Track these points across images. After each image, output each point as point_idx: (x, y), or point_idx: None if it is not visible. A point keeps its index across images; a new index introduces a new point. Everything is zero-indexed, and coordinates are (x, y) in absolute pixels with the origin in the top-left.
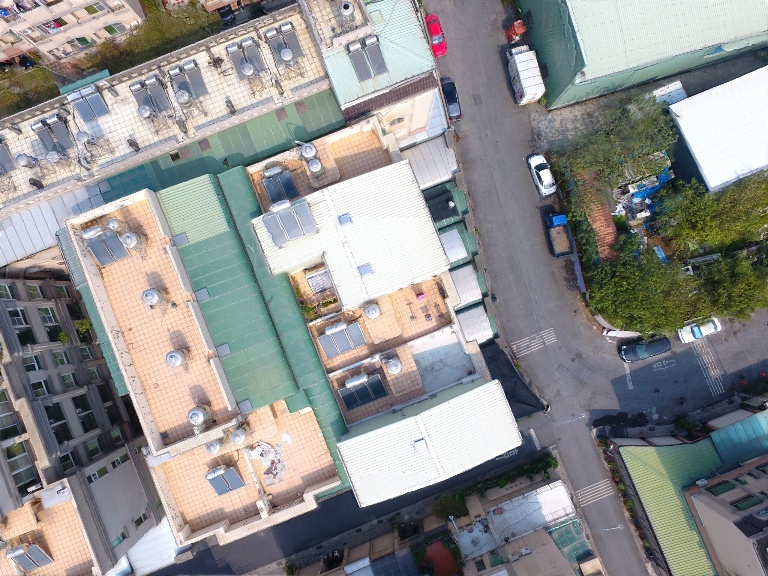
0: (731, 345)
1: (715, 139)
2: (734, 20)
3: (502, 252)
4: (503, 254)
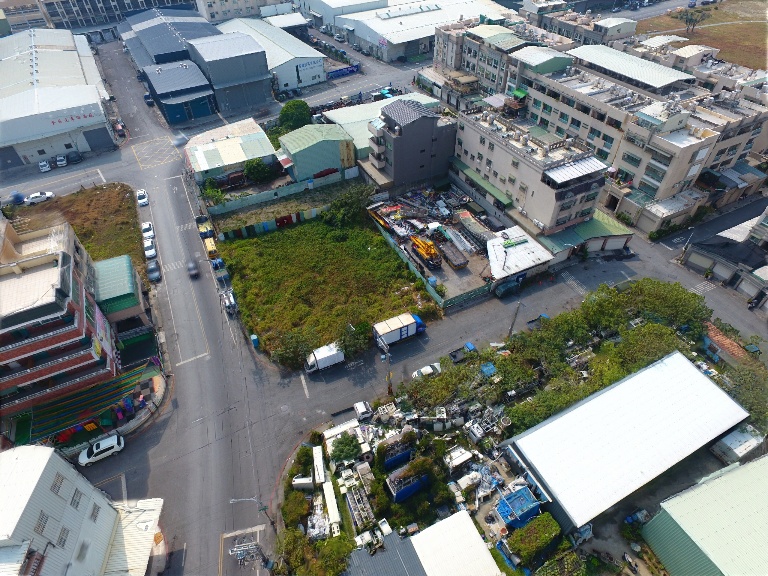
0: (567, 296)
1: (695, 389)
2: (761, 483)
3: (767, 336)
4: (766, 334)
